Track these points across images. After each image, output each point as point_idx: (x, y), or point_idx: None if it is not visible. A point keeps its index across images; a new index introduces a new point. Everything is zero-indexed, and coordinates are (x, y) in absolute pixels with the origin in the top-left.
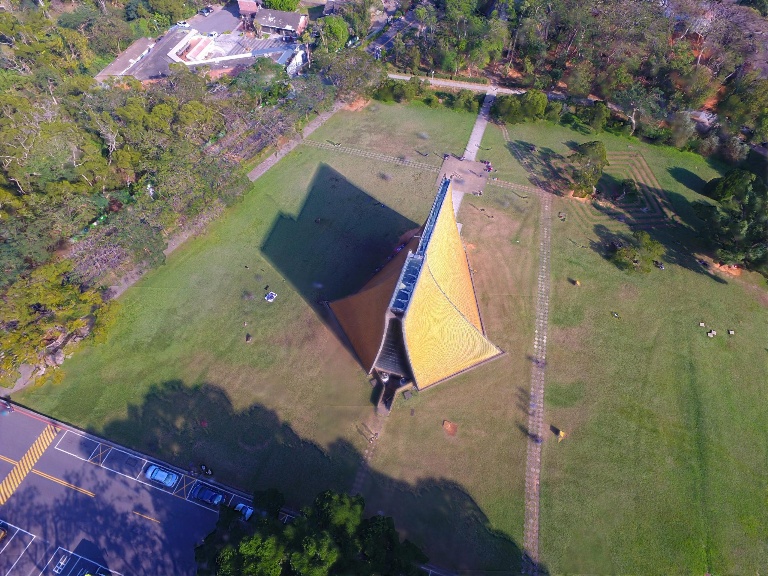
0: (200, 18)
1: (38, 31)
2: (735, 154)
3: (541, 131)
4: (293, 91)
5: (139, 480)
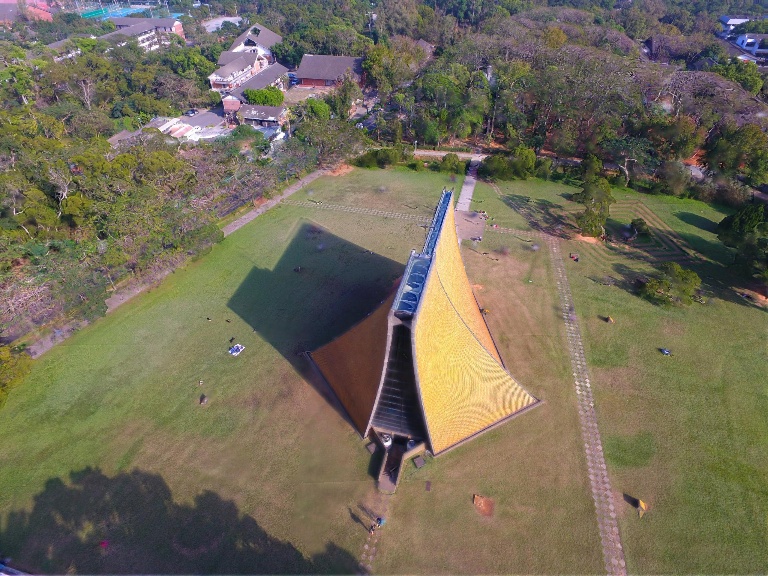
0: (185, 118)
1: (13, 116)
2: (739, 196)
3: (533, 186)
4: None
5: None
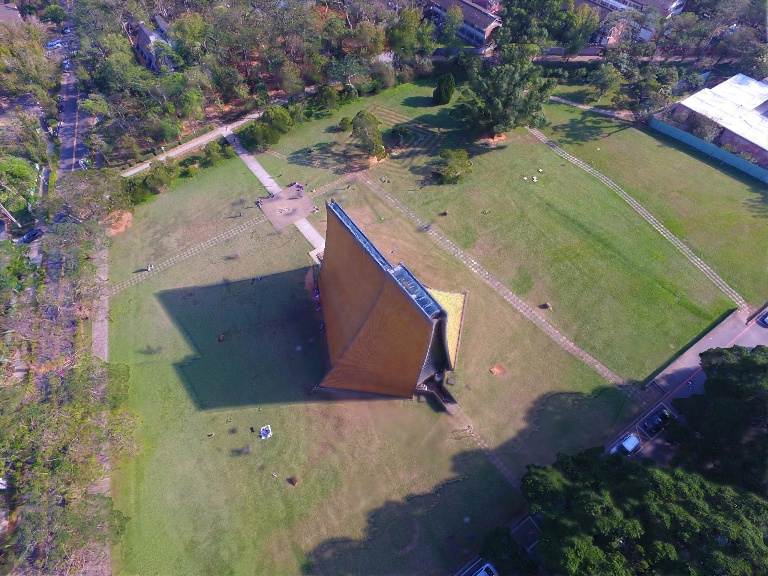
0: None
1: None
2: (427, 69)
3: (299, 135)
4: (30, 260)
5: None
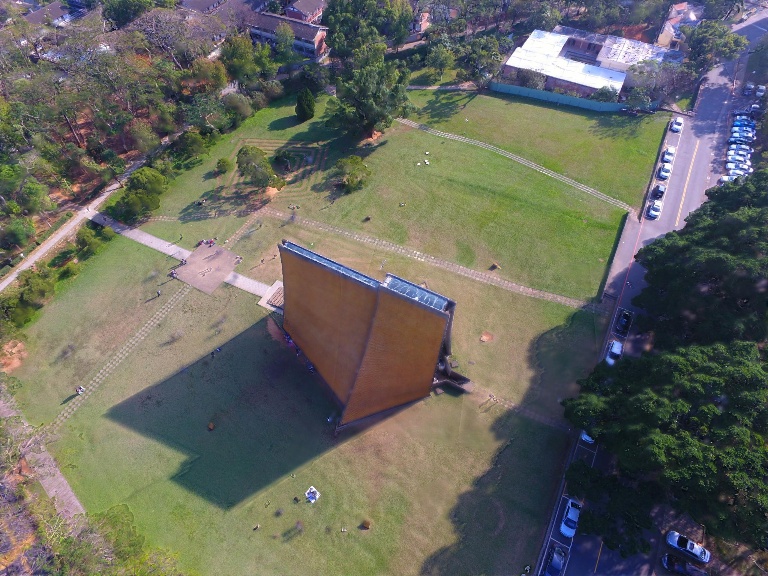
0: None
1: None
2: (277, 90)
3: (178, 191)
4: None
5: None
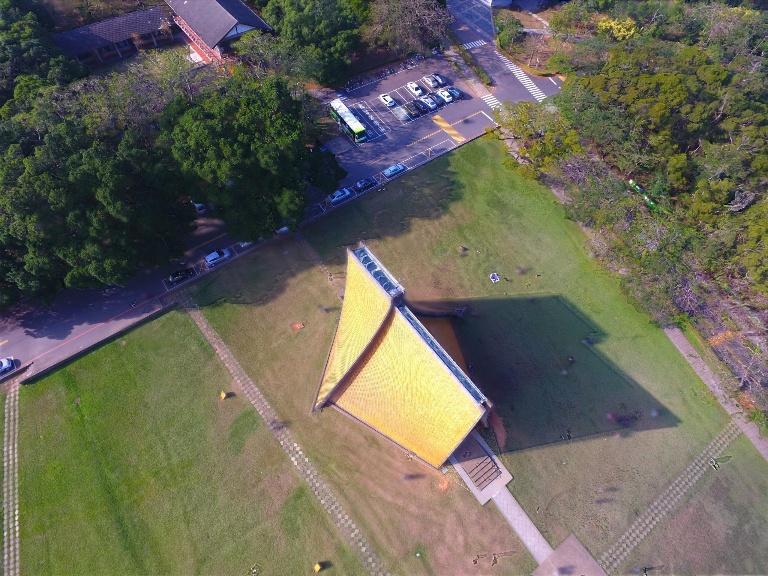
0: None
1: None
2: None
3: None
4: None
5: (401, 163)
